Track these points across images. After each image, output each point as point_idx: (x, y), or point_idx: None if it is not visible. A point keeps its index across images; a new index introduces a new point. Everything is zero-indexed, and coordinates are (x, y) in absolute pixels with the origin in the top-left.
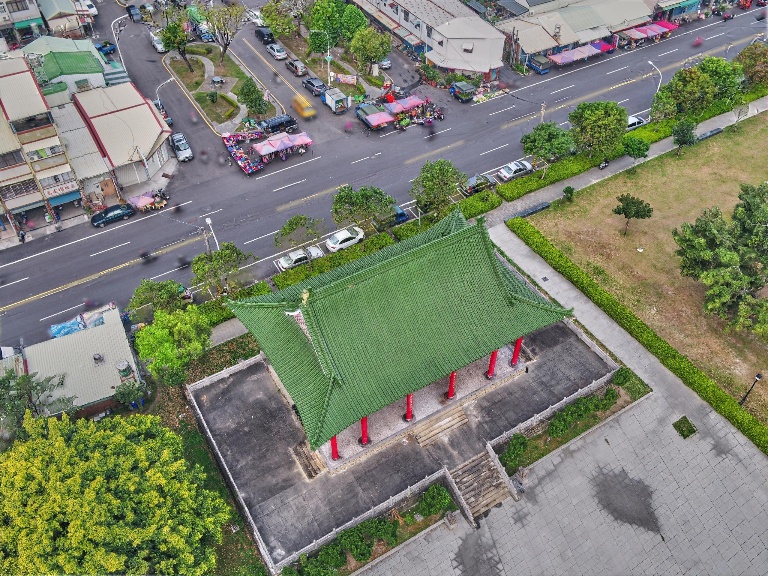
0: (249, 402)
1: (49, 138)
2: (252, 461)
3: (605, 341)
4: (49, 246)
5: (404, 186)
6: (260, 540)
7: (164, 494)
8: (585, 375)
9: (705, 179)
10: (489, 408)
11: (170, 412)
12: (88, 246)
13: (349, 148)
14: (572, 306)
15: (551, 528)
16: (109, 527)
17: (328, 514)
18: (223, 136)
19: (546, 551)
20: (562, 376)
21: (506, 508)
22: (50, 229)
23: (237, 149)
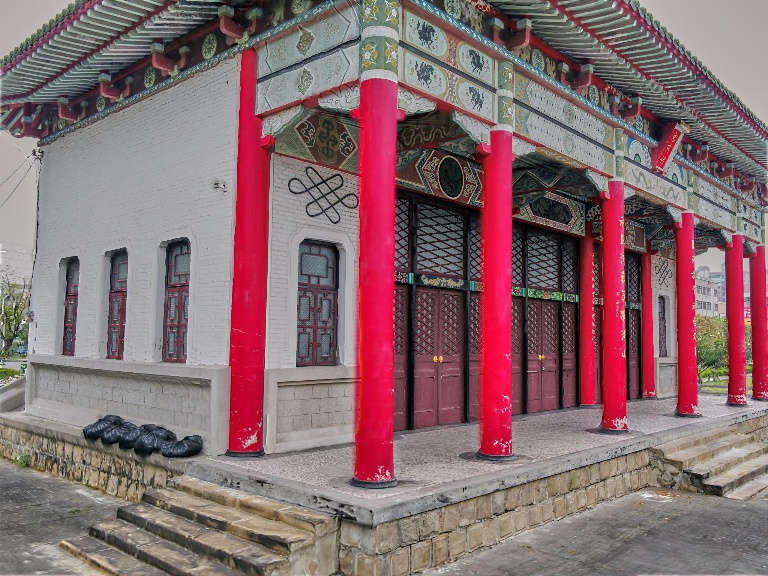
0: None
1: None
2: None
3: None
4: None
5: None
6: None
7: None
8: None
9: None
10: None
11: None
12: None
13: None
14: None
15: None
16: None
17: None
18: None
19: None
20: None
21: None
22: None
23: (1, 380)
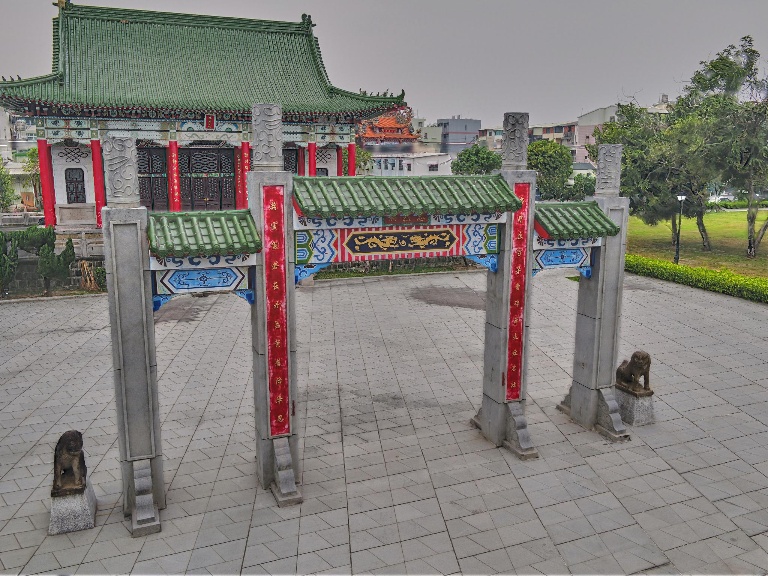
0: None
1: None
2: None
3: None
4: None
5: None
6: None
7: None
8: None
9: None
10: None
11: None
12: None
13: None
14: None
15: (316, 302)
16: None
17: None
18: None
19: None
20: None
21: None
22: None
23: None
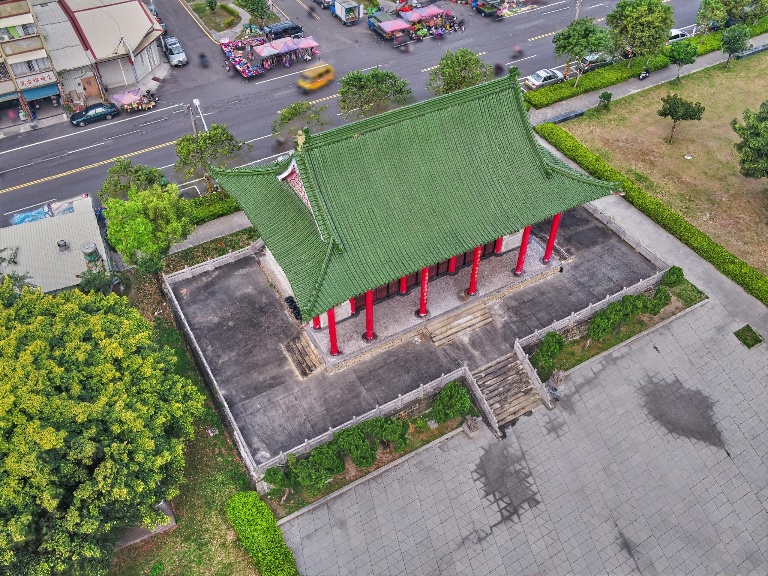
0: (236, 296)
1: (21, 15)
2: (236, 357)
3: (651, 246)
4: (22, 143)
5: (420, 92)
6: (240, 439)
7: (122, 371)
8: (630, 276)
9: (759, 91)
10: (517, 308)
11: (145, 309)
12: (65, 144)
13: (360, 56)
14: (611, 211)
15: (592, 440)
16: (48, 398)
17: (324, 415)
18: (221, 42)
19: (586, 464)
20: (603, 277)
21: (537, 417)
22: (24, 127)
23: None
